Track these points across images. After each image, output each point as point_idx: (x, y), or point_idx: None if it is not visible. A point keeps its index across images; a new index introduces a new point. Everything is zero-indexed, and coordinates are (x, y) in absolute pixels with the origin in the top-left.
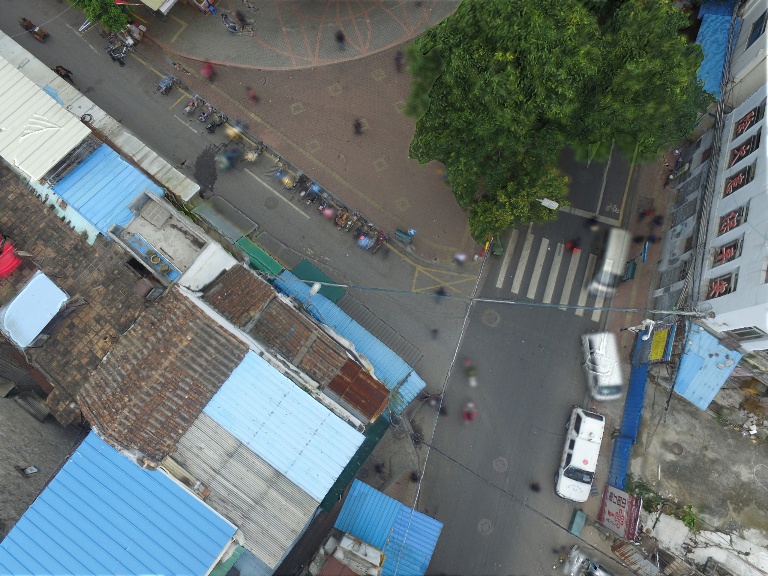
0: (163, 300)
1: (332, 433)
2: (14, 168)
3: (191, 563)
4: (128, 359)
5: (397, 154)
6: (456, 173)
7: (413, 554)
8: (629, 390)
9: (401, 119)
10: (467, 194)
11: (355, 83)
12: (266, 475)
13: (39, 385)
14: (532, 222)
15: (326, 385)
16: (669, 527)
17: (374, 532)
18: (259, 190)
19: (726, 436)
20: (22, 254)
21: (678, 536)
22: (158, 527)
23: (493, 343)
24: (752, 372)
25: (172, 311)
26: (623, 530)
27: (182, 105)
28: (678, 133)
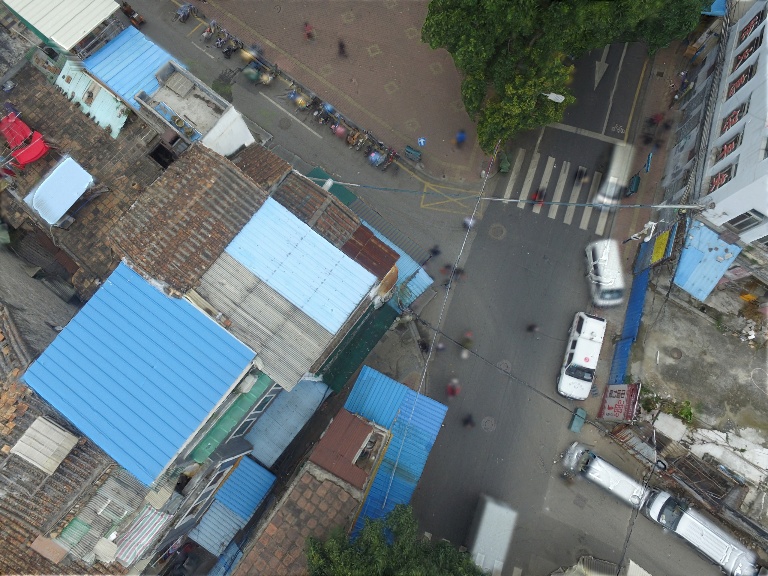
0: (188, 153)
1: (346, 273)
2: (41, 68)
3: (213, 381)
4: (155, 204)
5: (408, 78)
6: (466, 54)
7: (419, 434)
8: (631, 298)
9: (412, 45)
10: (476, 97)
11: (368, 11)
12: (283, 309)
13: (65, 267)
14: (539, 142)
15: (339, 248)
16: (667, 425)
17: (382, 413)
18: (273, 112)
19: (725, 342)
20: (49, 146)
21: (676, 433)
22: (183, 349)
23: (499, 254)
24: (751, 269)
25: (196, 162)
26: (622, 416)
27: (199, 32)
28: (682, 27)
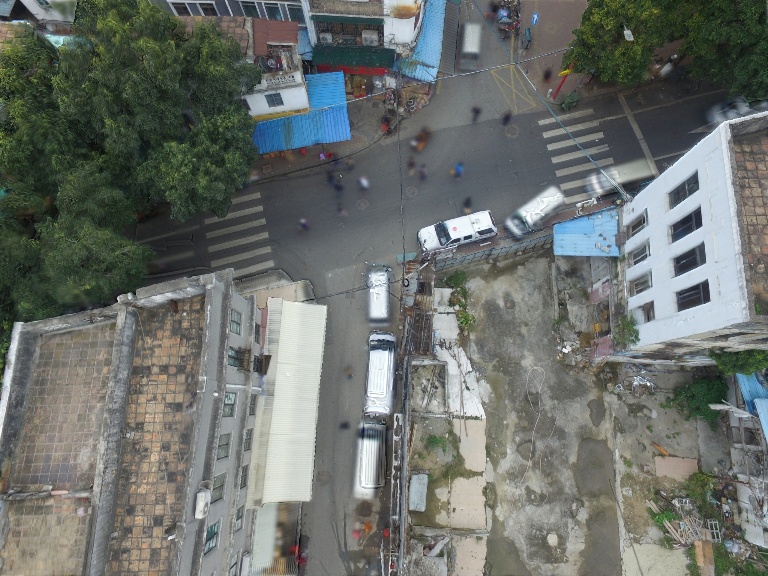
0: None
1: None
2: None
3: None
4: None
5: None
6: None
7: (320, 130)
8: None
9: None
10: (592, 6)
11: None
12: None
13: None
14: (609, 118)
15: None
16: (448, 324)
17: (318, 99)
18: None
19: (547, 335)
20: None
21: (446, 333)
22: None
23: (494, 142)
24: None
25: None
26: None
27: None
28: (761, 72)
